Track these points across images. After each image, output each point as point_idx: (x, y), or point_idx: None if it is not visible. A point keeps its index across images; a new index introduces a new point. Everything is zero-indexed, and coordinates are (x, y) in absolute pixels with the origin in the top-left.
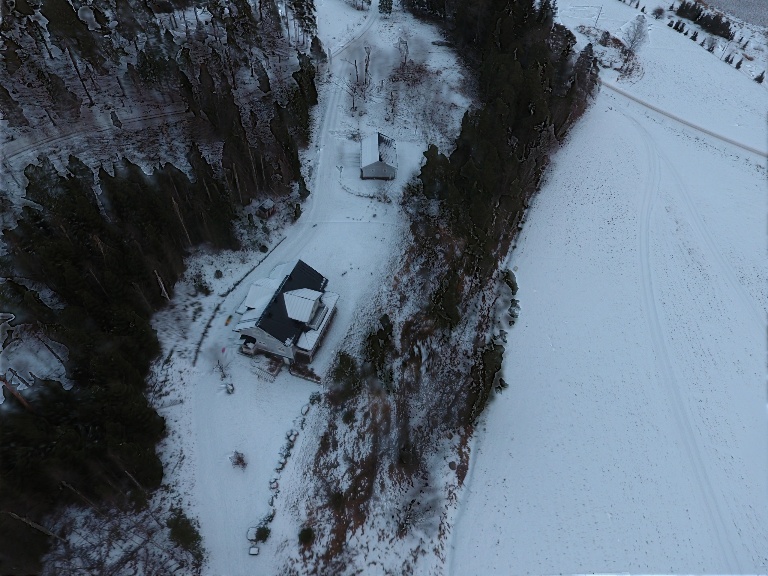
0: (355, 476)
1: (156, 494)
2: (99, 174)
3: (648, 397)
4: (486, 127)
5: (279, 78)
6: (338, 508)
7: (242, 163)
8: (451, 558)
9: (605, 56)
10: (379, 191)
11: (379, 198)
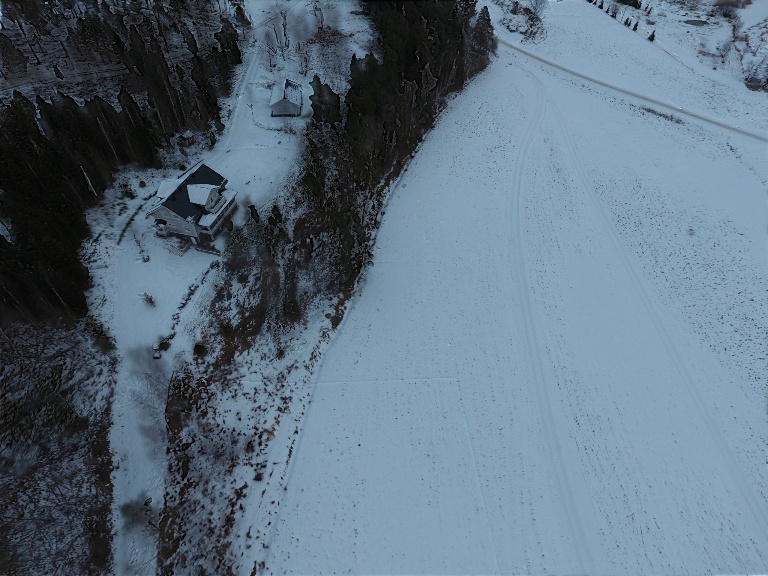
0: (244, 317)
1: (82, 320)
2: (37, 100)
3: (498, 270)
4: (372, 68)
5: (209, 43)
6: (228, 336)
7: (163, 100)
8: (318, 372)
9: (513, 22)
10: (286, 125)
11: (286, 131)
